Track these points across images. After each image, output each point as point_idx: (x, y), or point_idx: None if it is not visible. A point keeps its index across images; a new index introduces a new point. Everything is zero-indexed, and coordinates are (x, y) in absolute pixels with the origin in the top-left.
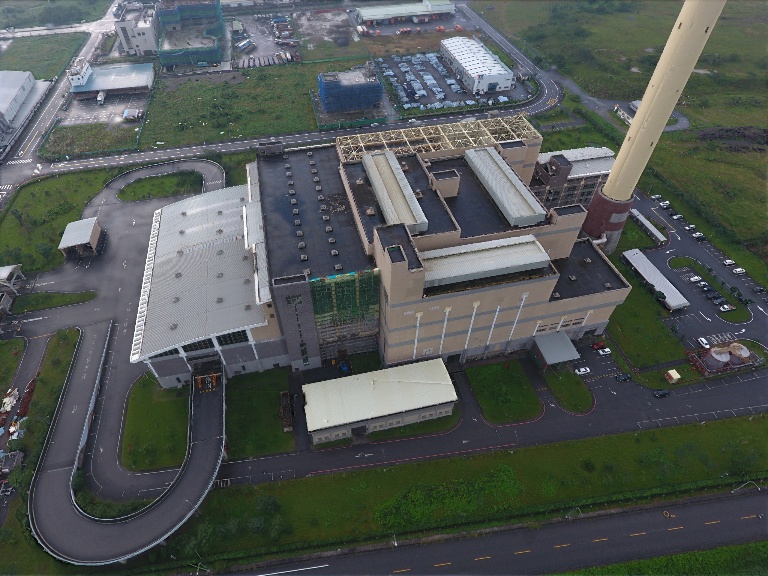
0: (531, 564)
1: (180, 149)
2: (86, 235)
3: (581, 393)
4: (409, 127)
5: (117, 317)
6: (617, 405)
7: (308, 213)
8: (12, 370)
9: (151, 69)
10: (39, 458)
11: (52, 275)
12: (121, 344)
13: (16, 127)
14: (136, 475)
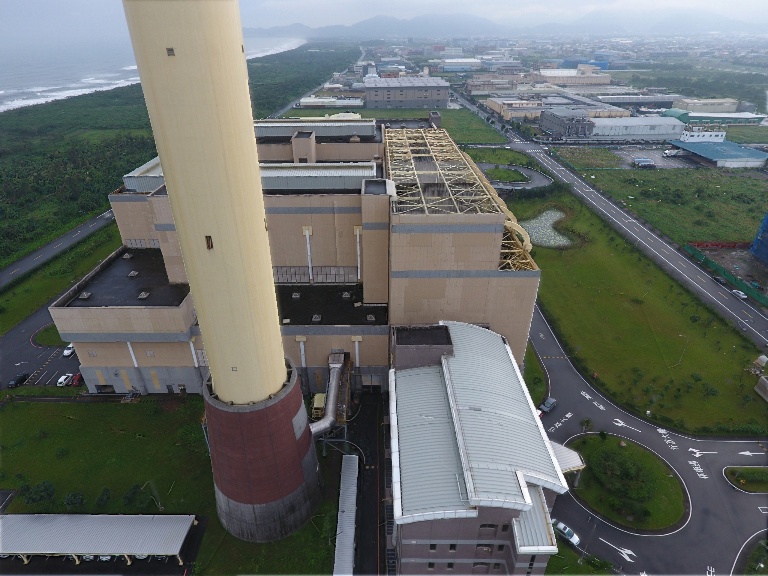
0: (4, 272)
1: (584, 184)
2: None
3: (55, 337)
4: (763, 333)
5: None
6: (7, 359)
7: None
8: None
9: (761, 158)
10: None
11: None
12: None
13: (591, 137)
14: None
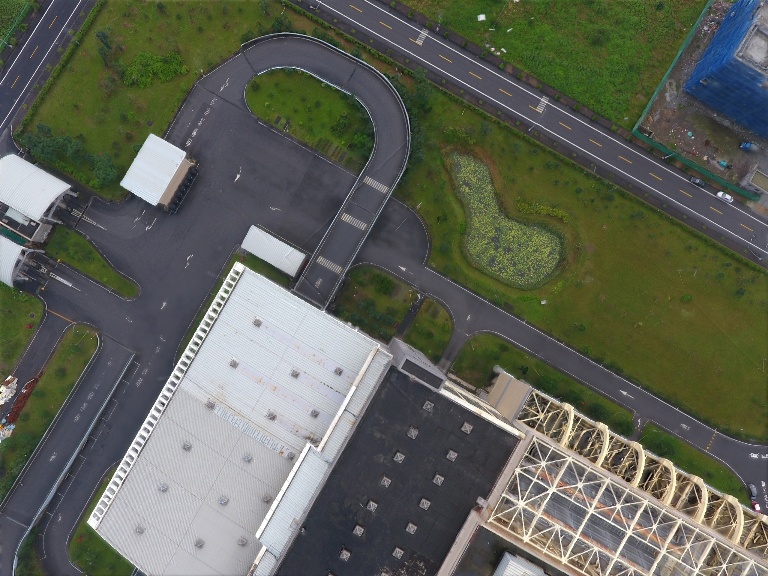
0: None
1: (394, 16)
2: (159, 187)
3: None
4: None
5: (142, 352)
6: None
7: (359, 569)
8: (20, 348)
9: None
10: (3, 500)
11: (106, 212)
12: (128, 398)
13: None
14: (75, 568)
